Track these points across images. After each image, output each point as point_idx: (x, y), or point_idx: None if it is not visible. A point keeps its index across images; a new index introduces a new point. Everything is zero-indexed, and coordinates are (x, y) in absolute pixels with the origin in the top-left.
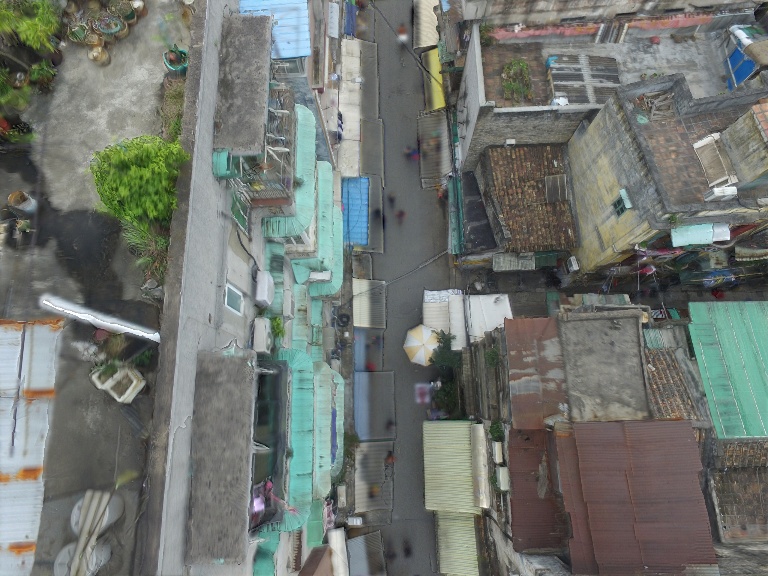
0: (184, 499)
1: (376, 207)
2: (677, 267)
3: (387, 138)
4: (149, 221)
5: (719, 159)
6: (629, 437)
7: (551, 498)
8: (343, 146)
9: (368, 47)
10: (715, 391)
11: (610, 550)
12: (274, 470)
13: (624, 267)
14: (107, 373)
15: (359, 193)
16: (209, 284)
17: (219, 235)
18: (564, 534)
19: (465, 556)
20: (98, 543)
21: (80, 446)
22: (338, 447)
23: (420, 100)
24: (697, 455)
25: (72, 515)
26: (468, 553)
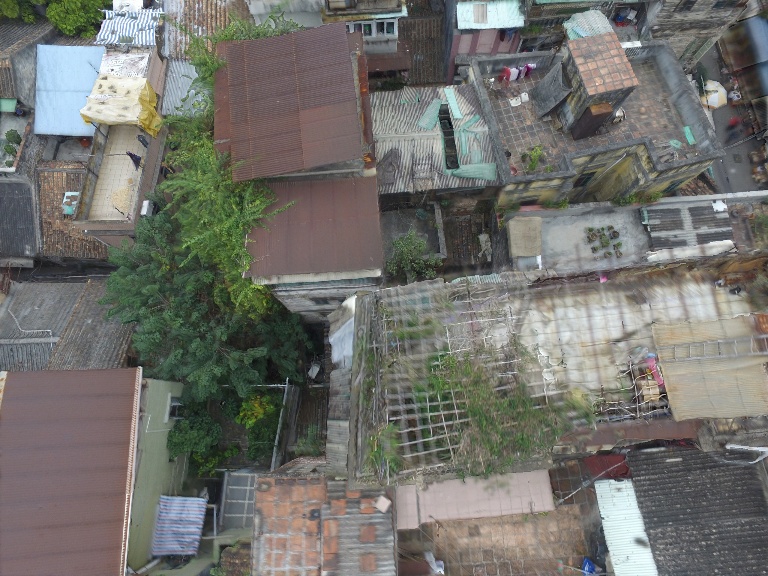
0: None
1: None
2: None
3: None
4: None
5: None
6: None
7: None
8: None
9: None
10: None
11: None
12: None
13: None
14: None
15: None
16: None
17: None
18: None
19: None
20: None
21: None
22: None
23: None
24: None
25: None
26: None
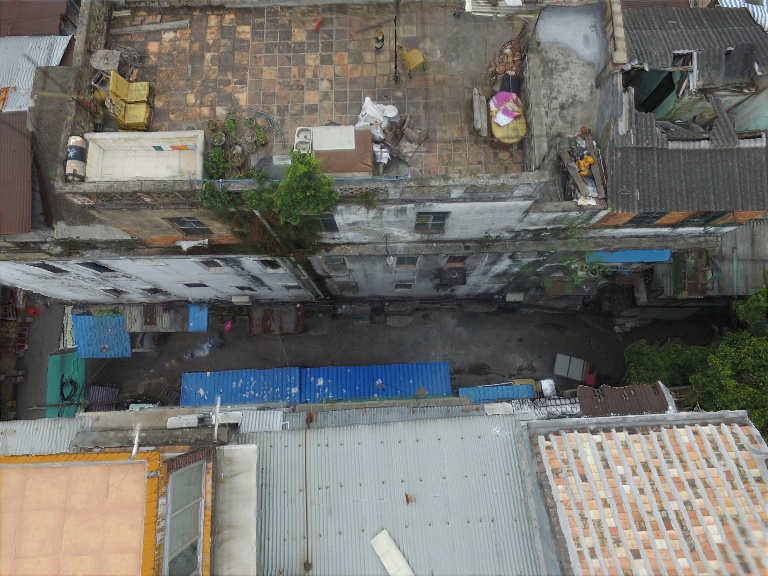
0: None
1: None
2: None
3: None
4: None
5: None
6: None
7: None
8: None
9: None
10: None
11: None
12: None
13: None
14: None
15: None
16: None
17: None
18: None
19: None
20: None
21: None
22: None
23: None
24: (64, 2)
25: None
26: None
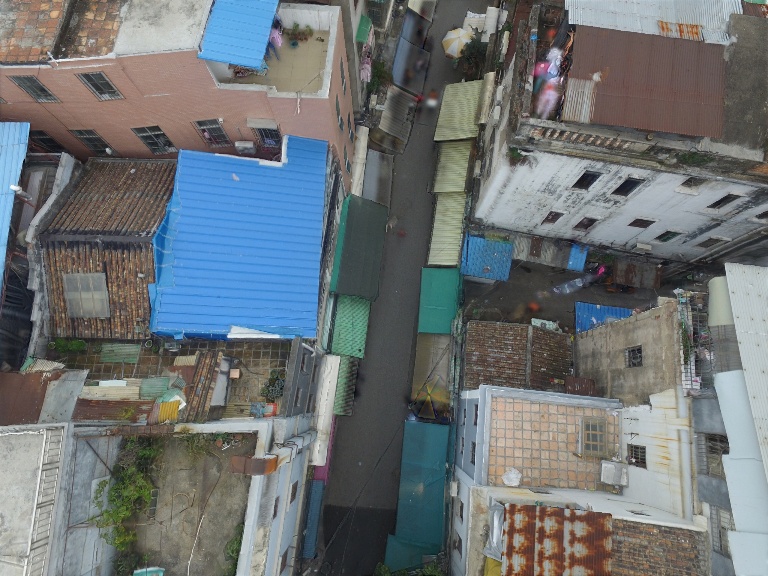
0: None
1: None
2: None
3: None
4: None
5: None
6: None
7: None
8: None
9: None
10: None
11: None
12: None
13: None
14: None
15: None
16: None
17: None
18: None
19: (456, 179)
20: None
21: None
22: None
23: None
24: None
25: None
26: (459, 177)
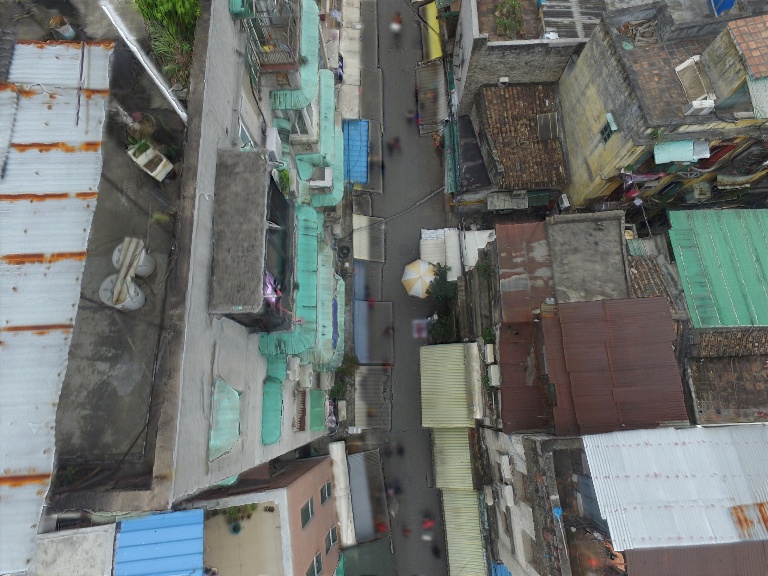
0: (207, 259)
1: (375, 150)
2: (663, 200)
3: (386, 91)
4: (177, 19)
5: (699, 79)
6: (609, 313)
7: (538, 386)
8: (344, 90)
9: (368, 1)
10: (692, 287)
11: (590, 412)
12: (283, 287)
13: (613, 202)
14: (141, 149)
15: (359, 135)
16: (226, 101)
17: (234, 68)
18: (550, 417)
19: (460, 470)
20: (135, 281)
21: (116, 220)
22: (339, 341)
23: (418, 55)
24: (671, 326)
25: (113, 255)
26: (463, 467)
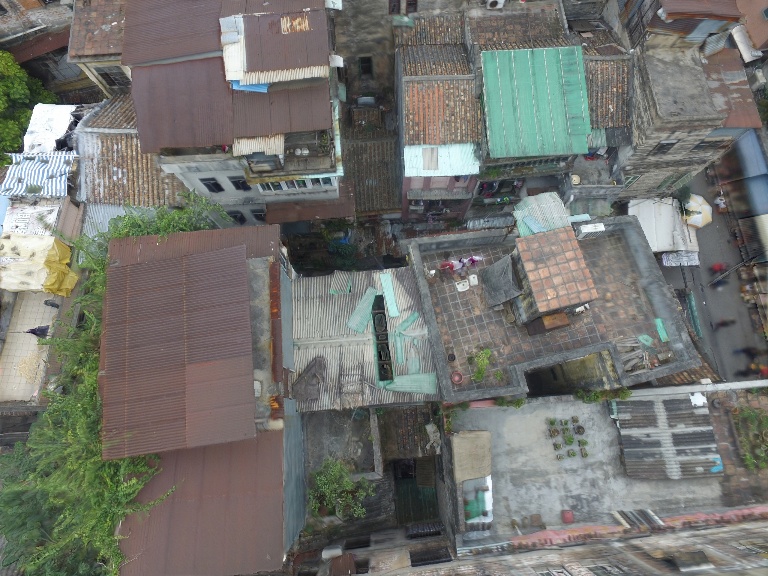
0: None
1: None
2: None
3: None
4: None
5: None
6: (707, 4)
7: None
8: None
9: None
10: (577, 80)
11: None
12: None
13: None
14: None
15: None
16: None
17: None
18: None
19: None
20: None
21: None
22: None
23: None
24: None
25: None
26: None
